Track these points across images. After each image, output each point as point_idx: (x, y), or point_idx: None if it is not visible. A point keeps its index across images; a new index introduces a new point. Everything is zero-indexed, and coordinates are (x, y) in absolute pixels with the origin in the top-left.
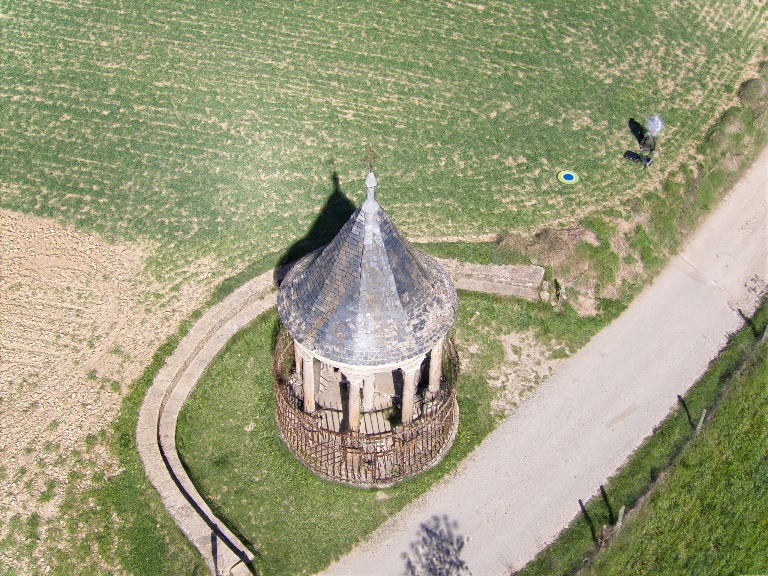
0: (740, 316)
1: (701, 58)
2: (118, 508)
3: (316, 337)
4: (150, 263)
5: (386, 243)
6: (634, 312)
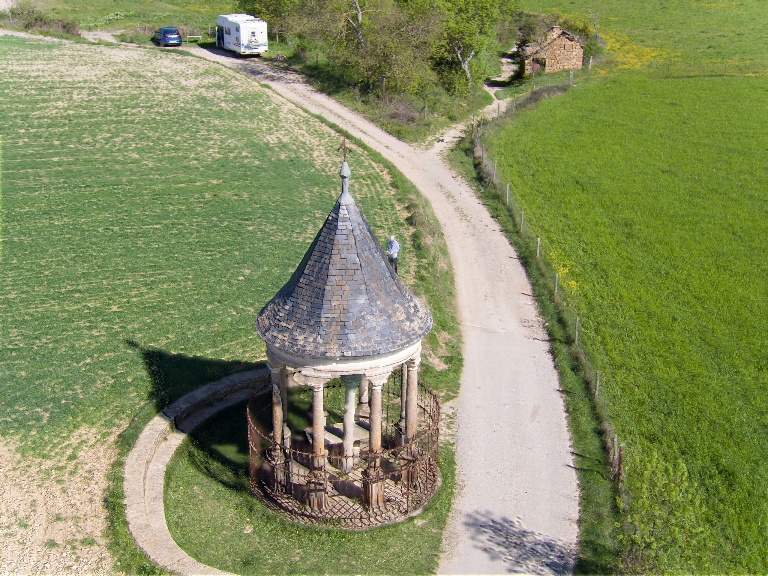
0: (542, 341)
1: None
2: None
3: (339, 342)
4: (24, 450)
5: (369, 232)
6: (471, 360)
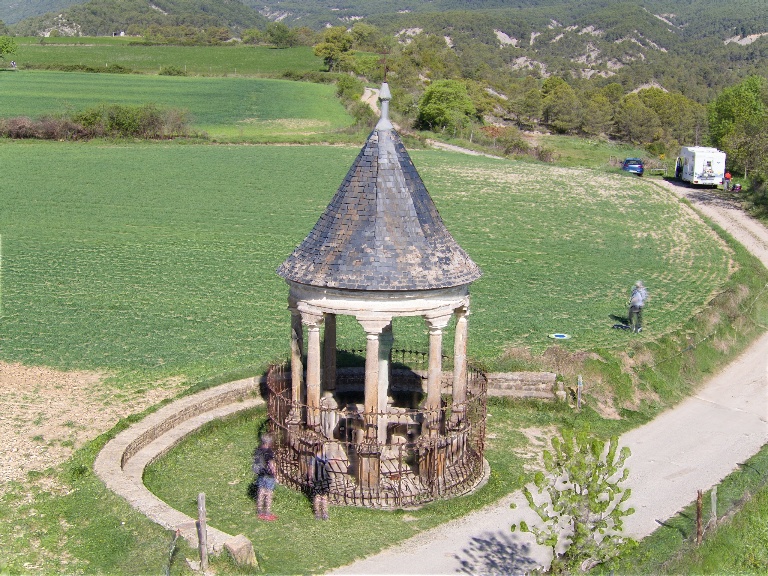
0: None
1: (664, 293)
2: (69, 515)
3: (327, 272)
4: (110, 379)
5: (402, 164)
6: (662, 422)
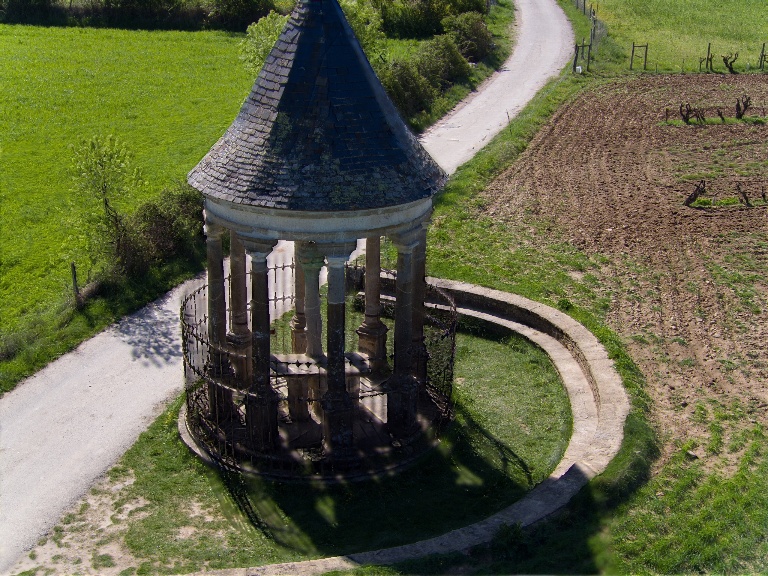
0: None
1: None
2: None
3: None
4: None
5: None
6: None
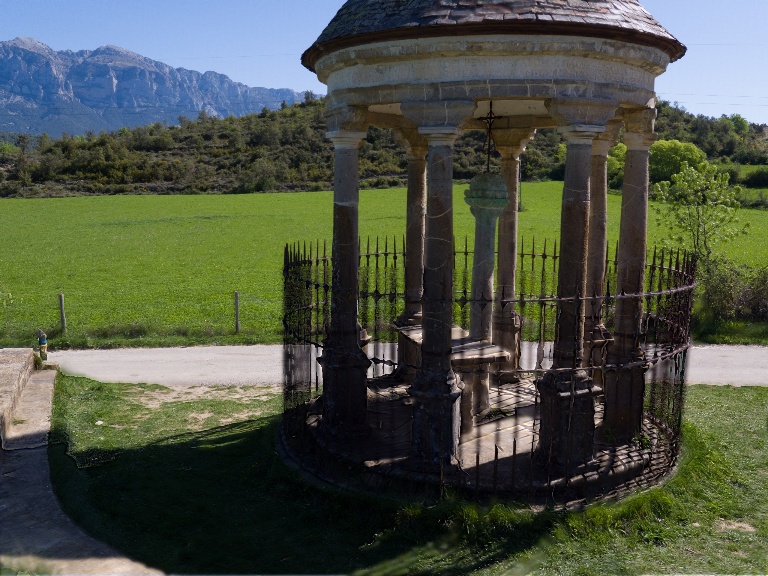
0: None
1: None
2: None
3: None
4: None
5: None
6: None
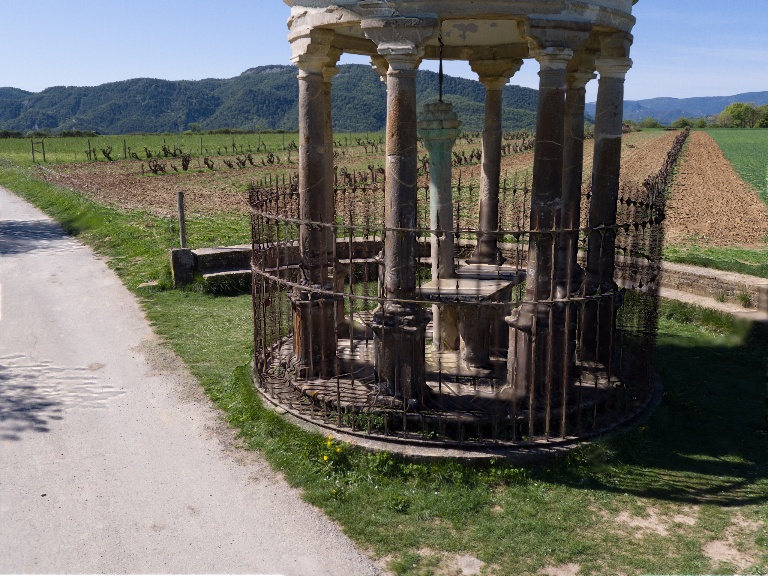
0: None
1: None
2: None
3: None
4: None
5: None
6: None
